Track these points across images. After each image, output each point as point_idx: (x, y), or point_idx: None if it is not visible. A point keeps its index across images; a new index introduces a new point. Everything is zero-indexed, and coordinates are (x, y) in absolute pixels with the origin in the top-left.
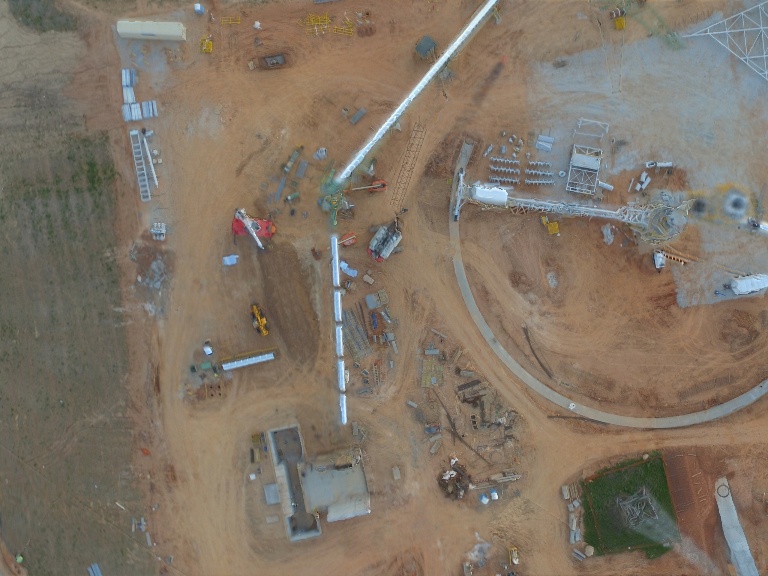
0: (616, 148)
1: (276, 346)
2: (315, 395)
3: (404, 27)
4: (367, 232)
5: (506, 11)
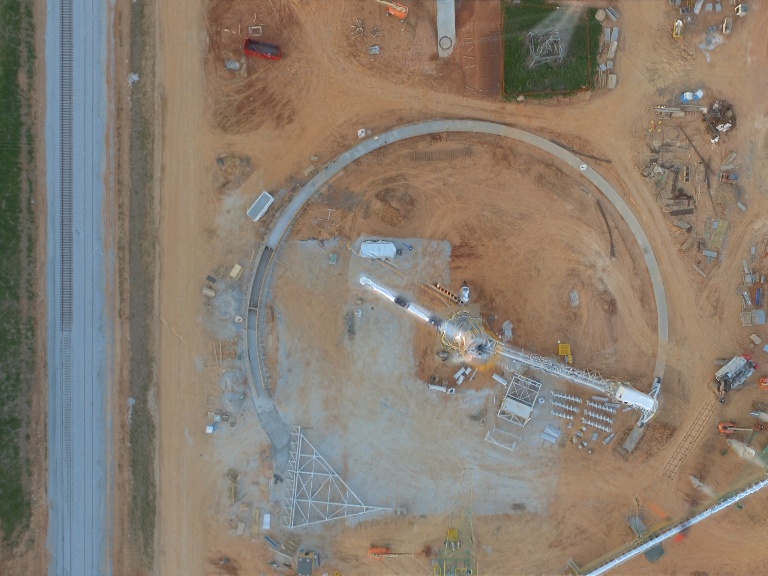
0: (482, 414)
1: None
2: None
3: (662, 573)
4: (746, 385)
5: (561, 569)
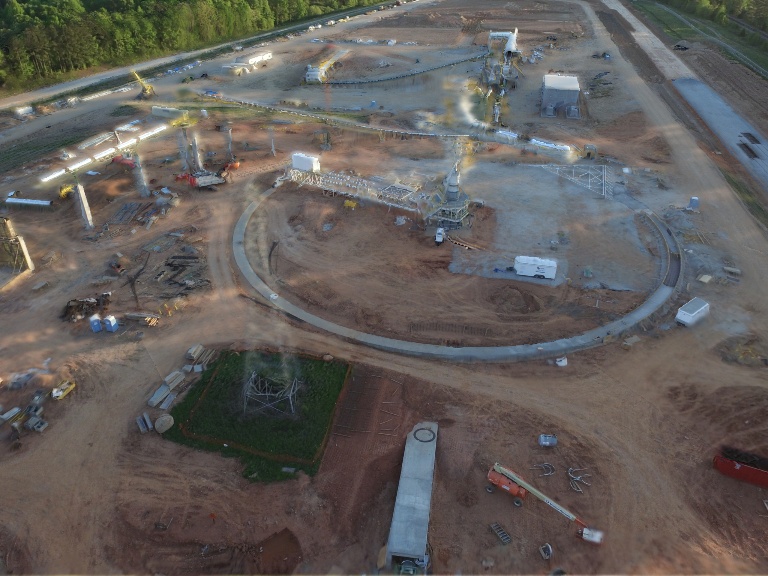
0: None
1: (61, 205)
2: (49, 234)
3: None
4: None
5: None
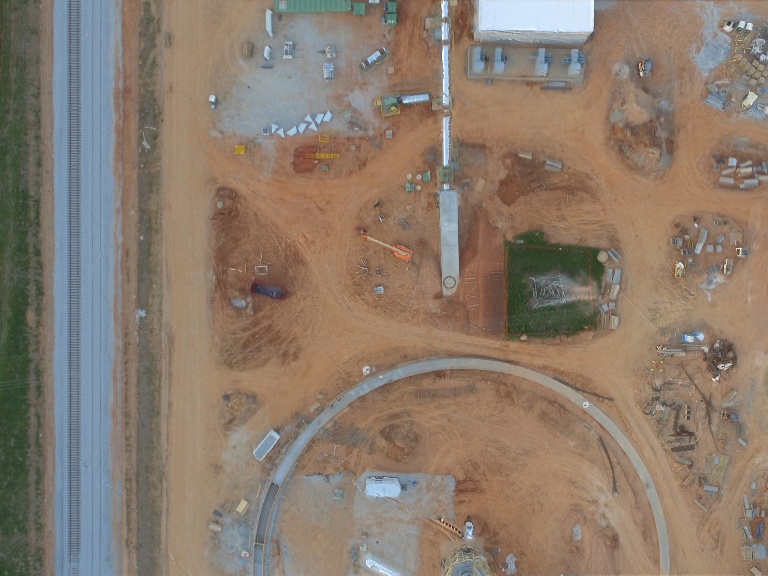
0: None
1: None
2: None
3: None
4: None
5: None
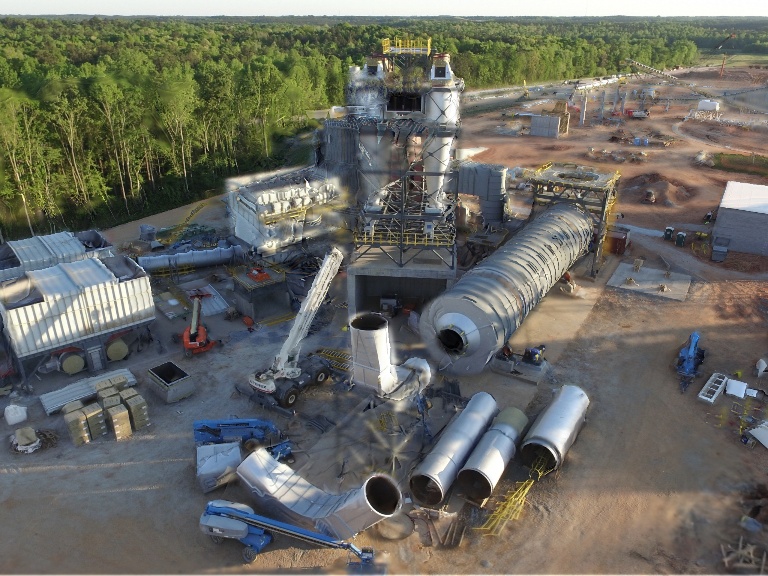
0: None
1: None
2: None
3: None
4: None
5: None
